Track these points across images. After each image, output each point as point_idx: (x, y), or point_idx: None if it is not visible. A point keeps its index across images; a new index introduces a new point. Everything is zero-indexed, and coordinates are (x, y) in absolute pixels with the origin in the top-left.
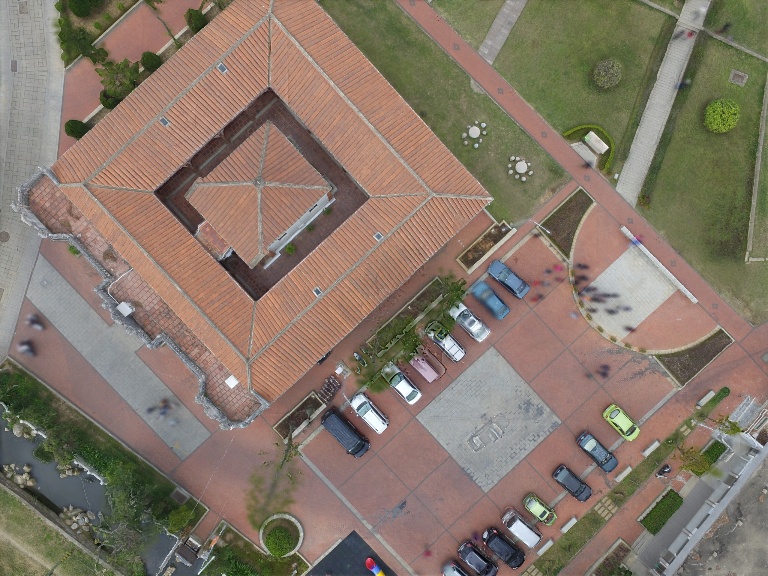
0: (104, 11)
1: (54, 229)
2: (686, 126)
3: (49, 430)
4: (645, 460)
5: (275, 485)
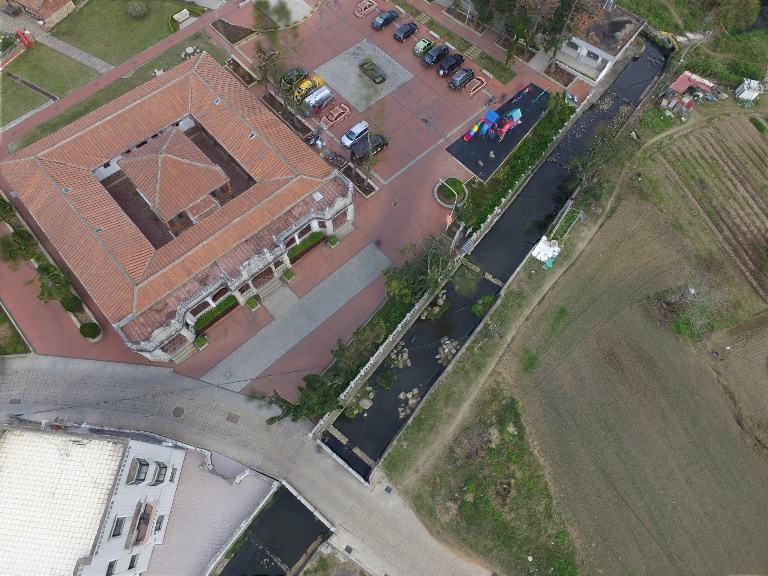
0: None
1: None
2: None
3: (354, 338)
4: (391, 1)
5: (412, 199)
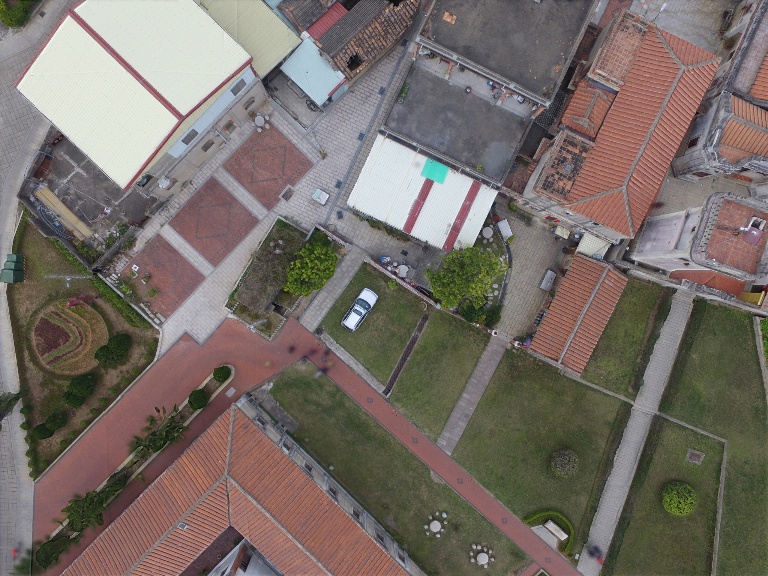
0: (69, 423)
1: None
2: (644, 505)
3: None
4: None
5: None
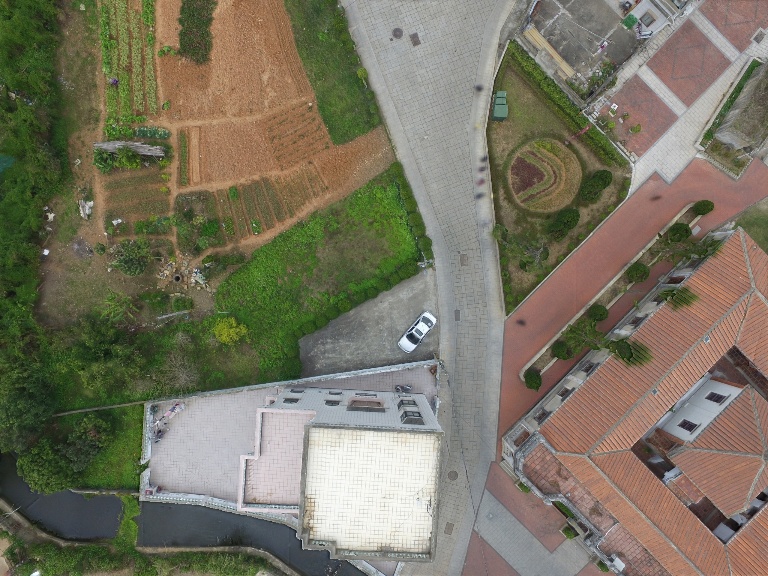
0: None
1: (544, 489)
2: None
3: None
4: None
5: None
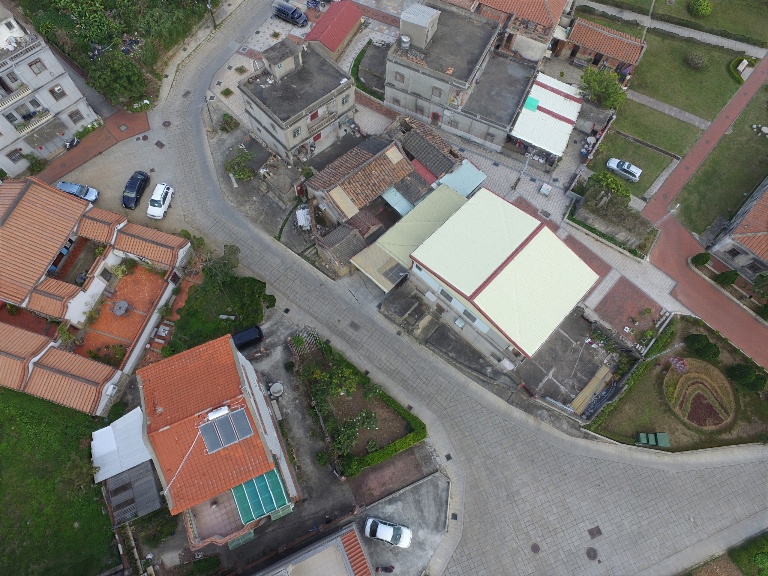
0: None
1: None
2: (709, 25)
3: None
4: None
5: None
